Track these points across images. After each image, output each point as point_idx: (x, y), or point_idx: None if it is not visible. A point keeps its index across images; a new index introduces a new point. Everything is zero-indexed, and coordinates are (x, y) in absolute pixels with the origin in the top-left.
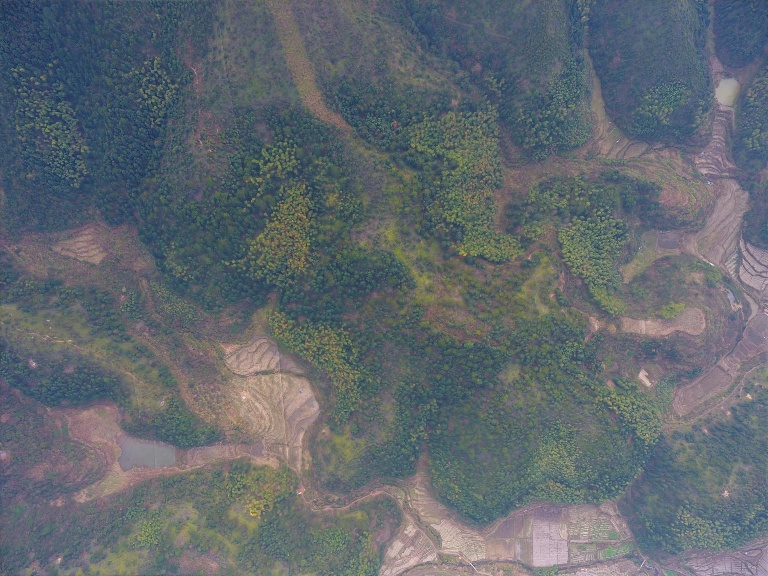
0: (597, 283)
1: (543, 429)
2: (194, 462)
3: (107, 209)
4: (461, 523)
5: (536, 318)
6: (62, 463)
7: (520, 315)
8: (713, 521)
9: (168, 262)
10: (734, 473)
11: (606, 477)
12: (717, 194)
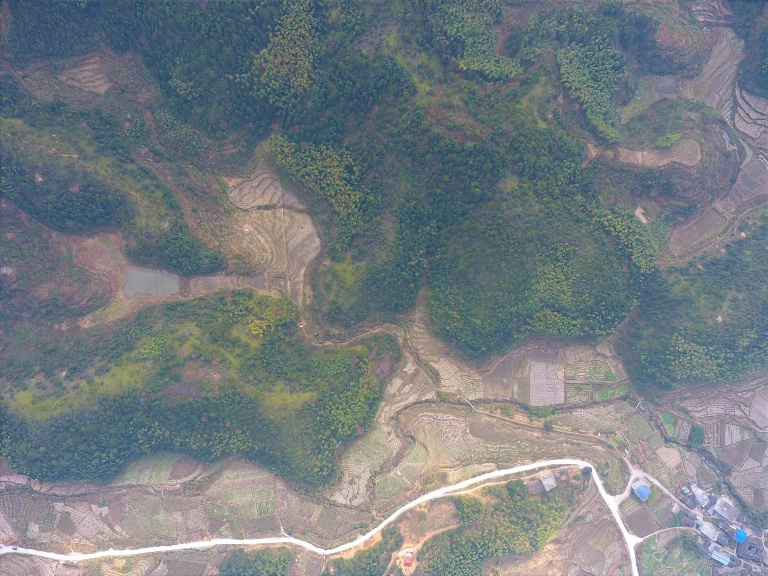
0: (595, 111)
1: (541, 247)
2: (197, 291)
3: (113, 31)
4: (459, 360)
5: (534, 128)
6: (67, 284)
7: (519, 118)
8: (707, 347)
9: (173, 80)
10: (728, 300)
11: (602, 304)
12: (713, 41)
